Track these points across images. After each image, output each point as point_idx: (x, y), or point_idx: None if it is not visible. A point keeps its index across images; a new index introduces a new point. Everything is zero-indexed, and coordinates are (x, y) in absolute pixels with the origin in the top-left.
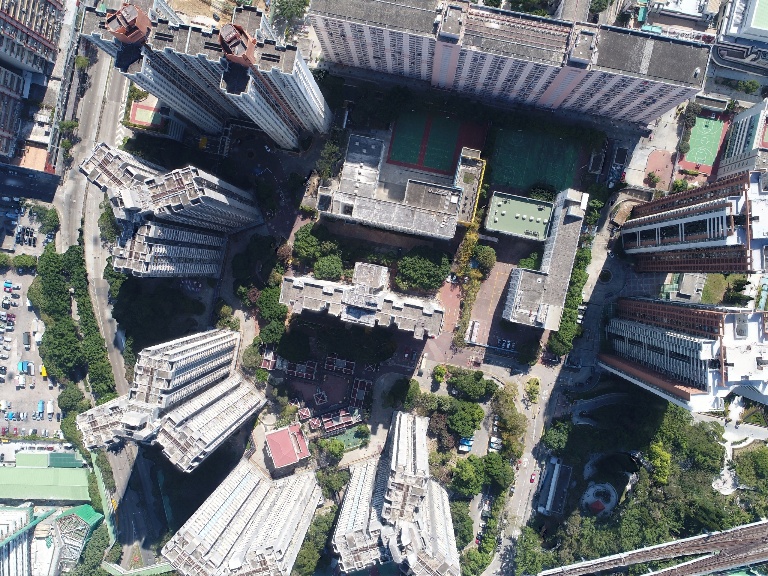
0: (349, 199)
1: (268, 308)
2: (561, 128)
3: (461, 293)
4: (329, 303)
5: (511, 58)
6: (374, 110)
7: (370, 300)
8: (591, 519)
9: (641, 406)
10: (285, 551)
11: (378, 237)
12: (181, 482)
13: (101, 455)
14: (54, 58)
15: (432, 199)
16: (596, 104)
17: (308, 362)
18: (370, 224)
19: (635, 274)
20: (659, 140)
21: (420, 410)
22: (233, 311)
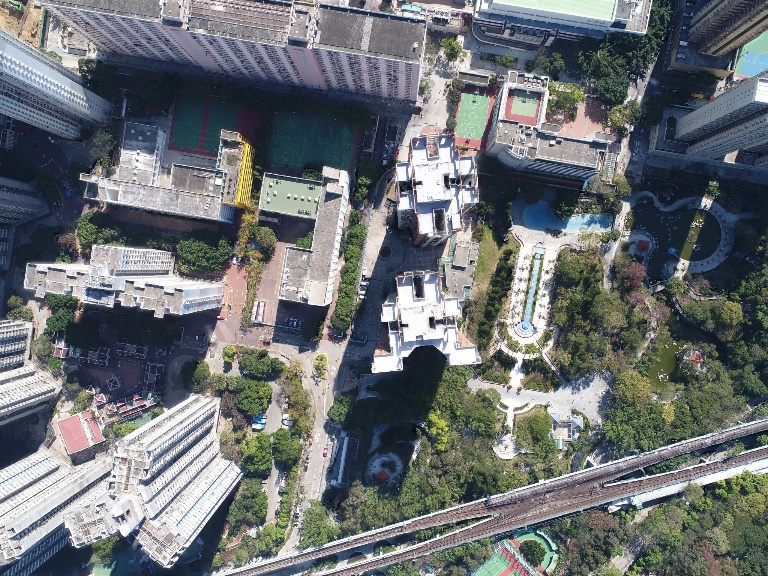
0: (114, 185)
1: (54, 297)
2: (330, 108)
3: (247, 274)
4: (73, 286)
5: (237, 39)
6: (150, 97)
7: (104, 281)
8: (373, 489)
9: (415, 376)
10: (30, 530)
11: (164, 223)
12: None
13: None
14: None
15: (197, 182)
16: (356, 83)
17: (100, 348)
18: (153, 210)
19: (414, 249)
20: (430, 117)
21: (209, 391)
22: (26, 302)
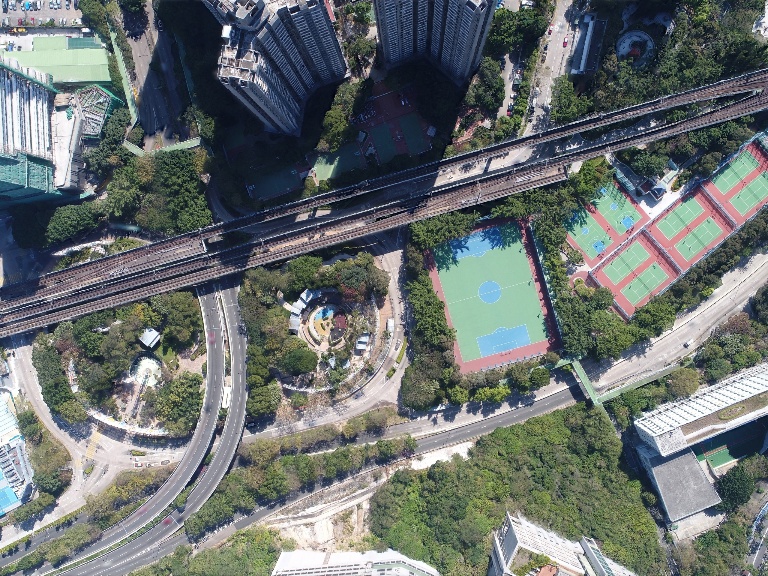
0: None
1: None
2: None
3: None
4: None
5: None
6: None
7: None
8: (628, 60)
9: None
10: None
11: None
12: (203, 55)
13: (121, 34)
14: None
15: None
16: None
17: None
18: None
19: None
20: None
21: None
22: None
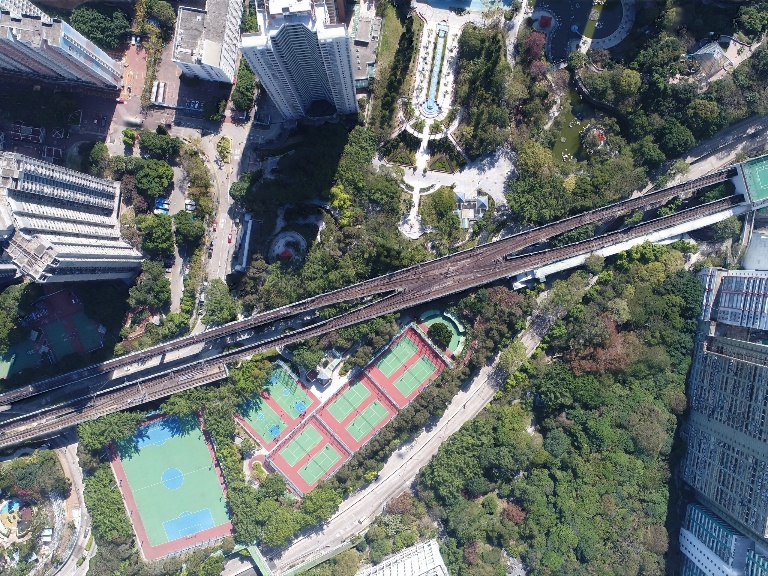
0: None
1: None
2: None
3: None
4: None
5: None
6: None
7: None
8: (276, 264)
9: (316, 148)
10: None
11: (59, 2)
12: None
13: None
14: None
15: None
16: None
17: None
18: None
19: None
20: None
21: (108, 172)
22: None
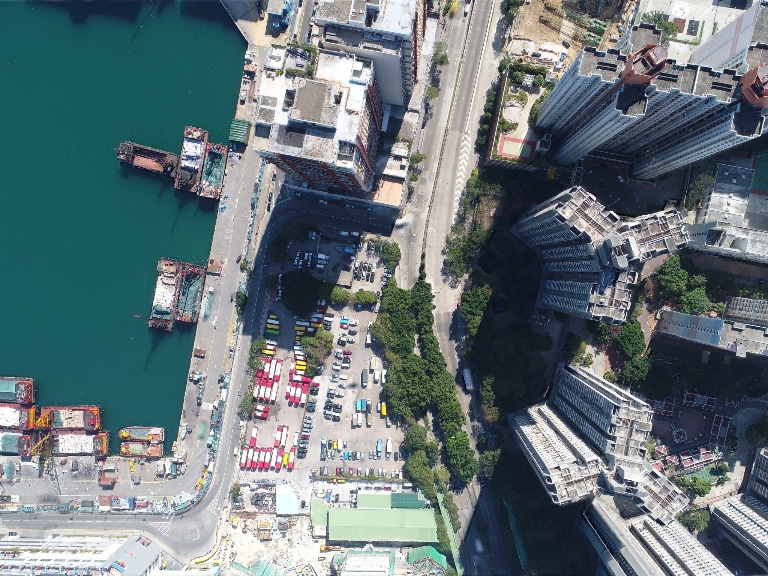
0: (742, 233)
1: (631, 344)
2: None
3: None
4: None
5: None
6: None
7: None
8: None
9: None
10: None
11: (737, 269)
12: (535, 523)
13: (448, 495)
14: None
15: None
16: None
17: (666, 398)
18: (733, 256)
19: None
20: None
21: None
22: None
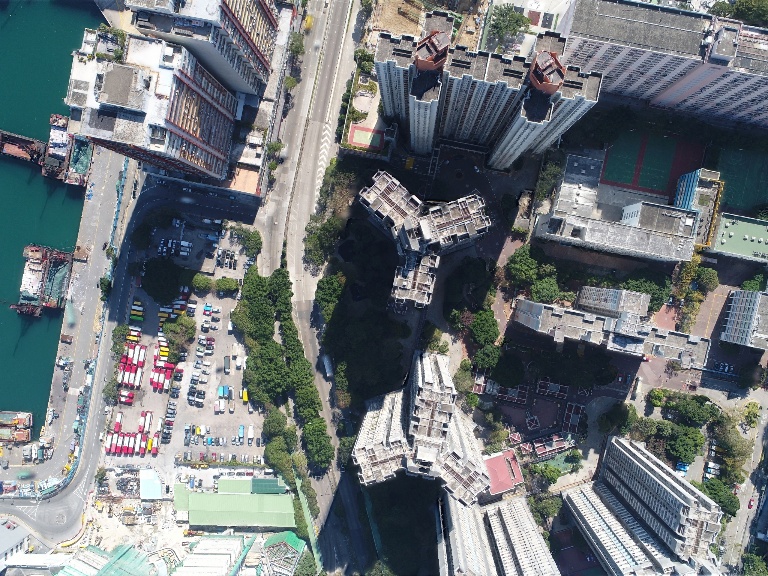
0: (582, 222)
1: (483, 332)
2: None
3: (676, 315)
4: (590, 331)
5: None
6: (591, 130)
7: (642, 329)
8: None
9: None
10: None
11: (591, 258)
12: (390, 509)
13: (306, 481)
14: (267, 79)
15: (666, 221)
16: None
17: (519, 386)
18: (585, 246)
19: None
20: None
21: (638, 435)
22: None
